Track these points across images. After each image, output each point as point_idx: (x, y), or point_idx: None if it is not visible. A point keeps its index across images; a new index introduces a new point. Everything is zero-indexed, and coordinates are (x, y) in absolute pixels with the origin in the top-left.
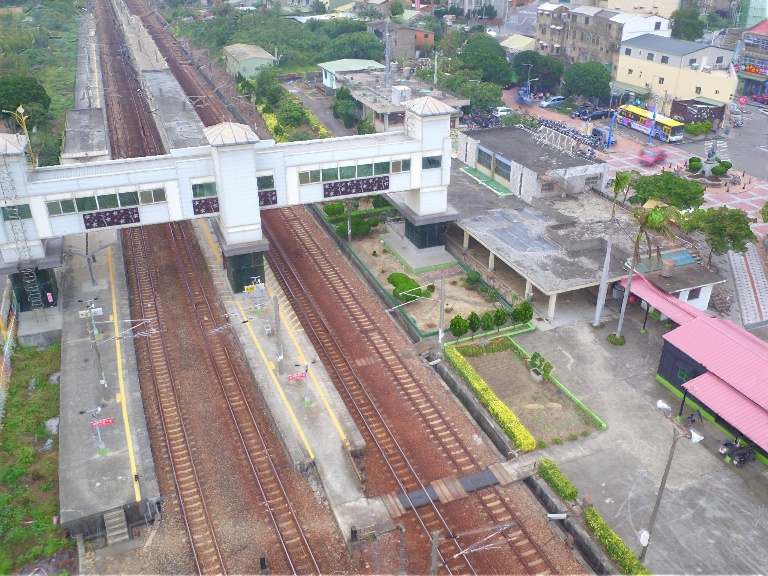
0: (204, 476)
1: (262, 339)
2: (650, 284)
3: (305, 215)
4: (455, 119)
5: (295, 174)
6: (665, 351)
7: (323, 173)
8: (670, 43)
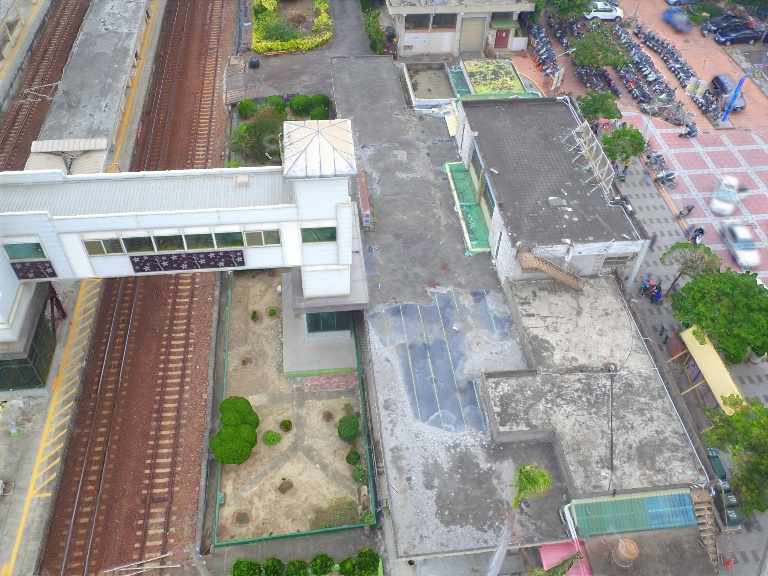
0: None
1: None
2: (585, 572)
3: None
4: (510, 28)
5: (77, 242)
6: None
7: (128, 241)
8: None
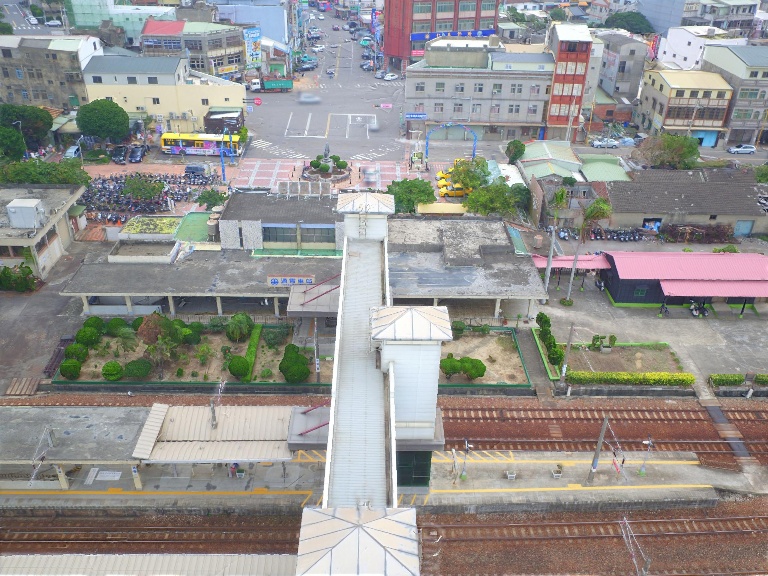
0: (723, 568)
1: (523, 484)
2: (543, 257)
3: (194, 398)
4: None
5: None
6: (622, 286)
7: None
8: (138, 63)
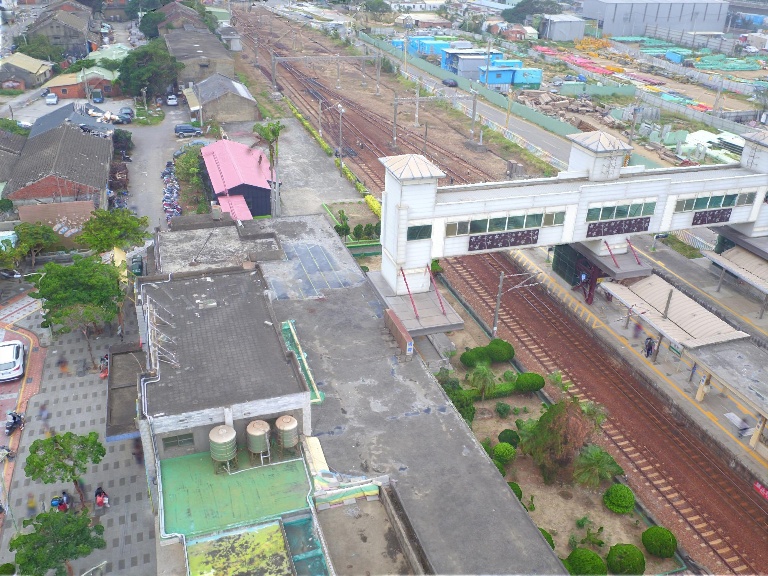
0: None
1: None
2: None
3: None
4: None
5: None
6: None
7: None
8: None
